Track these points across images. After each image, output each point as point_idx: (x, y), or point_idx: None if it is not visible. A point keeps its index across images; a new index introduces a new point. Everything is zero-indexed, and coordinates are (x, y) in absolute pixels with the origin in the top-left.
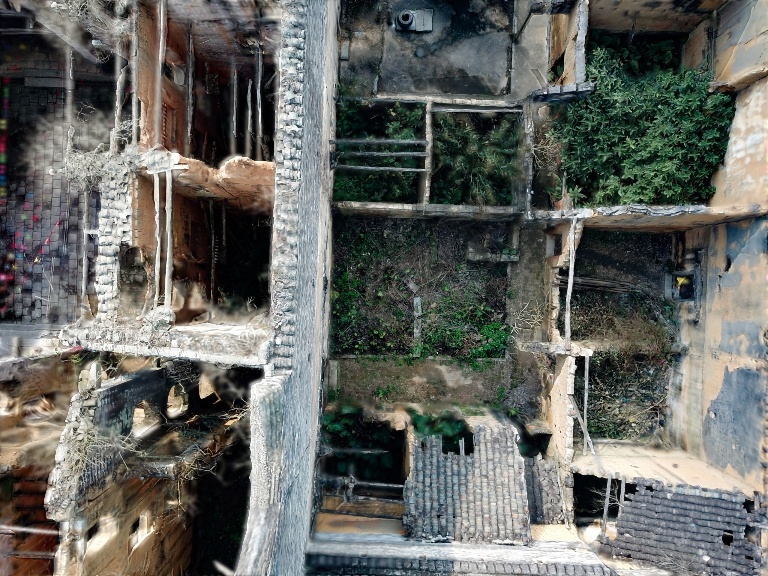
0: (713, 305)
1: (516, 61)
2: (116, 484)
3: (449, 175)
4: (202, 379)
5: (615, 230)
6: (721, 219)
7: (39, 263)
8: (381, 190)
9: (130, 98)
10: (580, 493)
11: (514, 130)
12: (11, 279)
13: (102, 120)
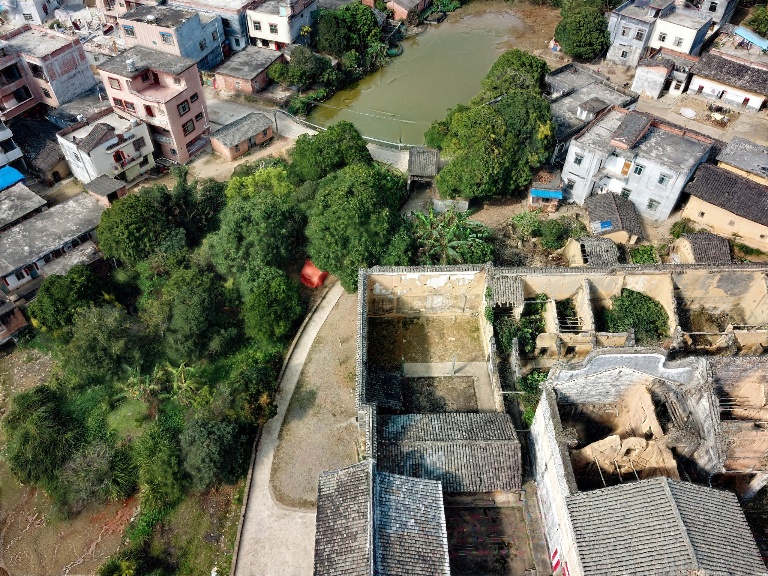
0: (689, 294)
1: None
2: None
3: None
4: None
5: None
6: None
7: None
8: None
9: (757, 425)
10: None
11: None
12: None
13: None
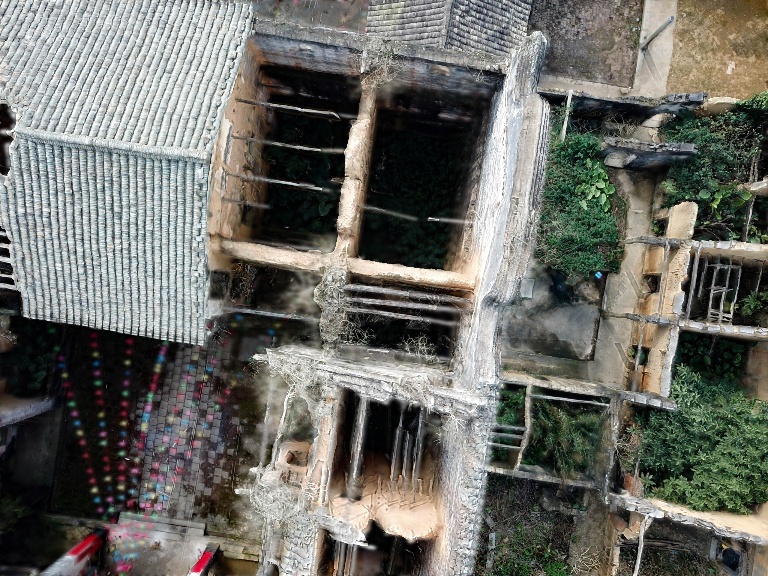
0: None
1: (602, 334)
2: None
3: None
4: None
5: None
6: None
7: (166, 463)
8: None
9: (320, 466)
10: None
11: (600, 421)
12: (139, 474)
13: (235, 344)
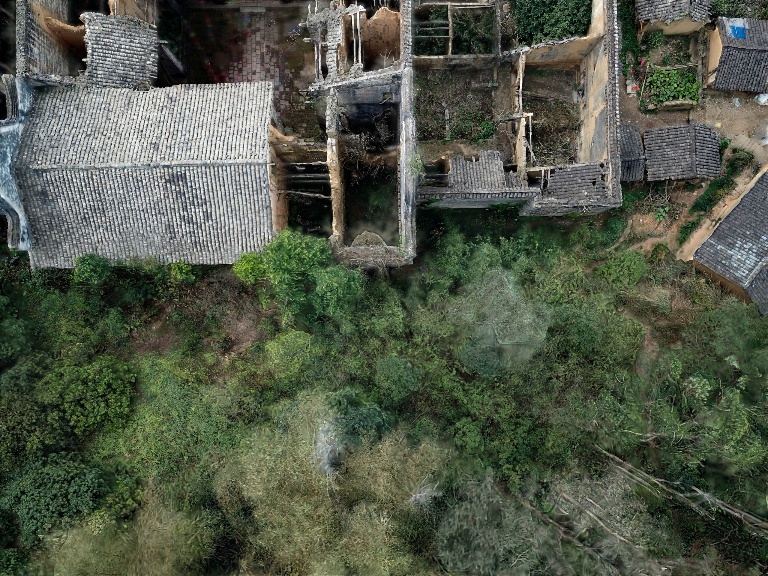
0: (591, 93)
1: None
2: (338, 141)
3: (460, 45)
4: (352, 132)
5: (546, 69)
6: (588, 46)
7: None
8: (426, 52)
9: None
10: (531, 183)
11: (491, 15)
12: None
13: (280, 28)
